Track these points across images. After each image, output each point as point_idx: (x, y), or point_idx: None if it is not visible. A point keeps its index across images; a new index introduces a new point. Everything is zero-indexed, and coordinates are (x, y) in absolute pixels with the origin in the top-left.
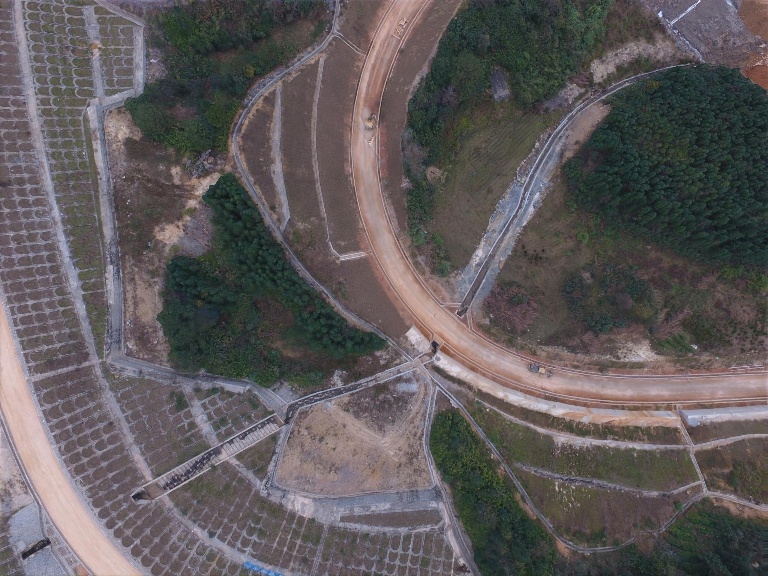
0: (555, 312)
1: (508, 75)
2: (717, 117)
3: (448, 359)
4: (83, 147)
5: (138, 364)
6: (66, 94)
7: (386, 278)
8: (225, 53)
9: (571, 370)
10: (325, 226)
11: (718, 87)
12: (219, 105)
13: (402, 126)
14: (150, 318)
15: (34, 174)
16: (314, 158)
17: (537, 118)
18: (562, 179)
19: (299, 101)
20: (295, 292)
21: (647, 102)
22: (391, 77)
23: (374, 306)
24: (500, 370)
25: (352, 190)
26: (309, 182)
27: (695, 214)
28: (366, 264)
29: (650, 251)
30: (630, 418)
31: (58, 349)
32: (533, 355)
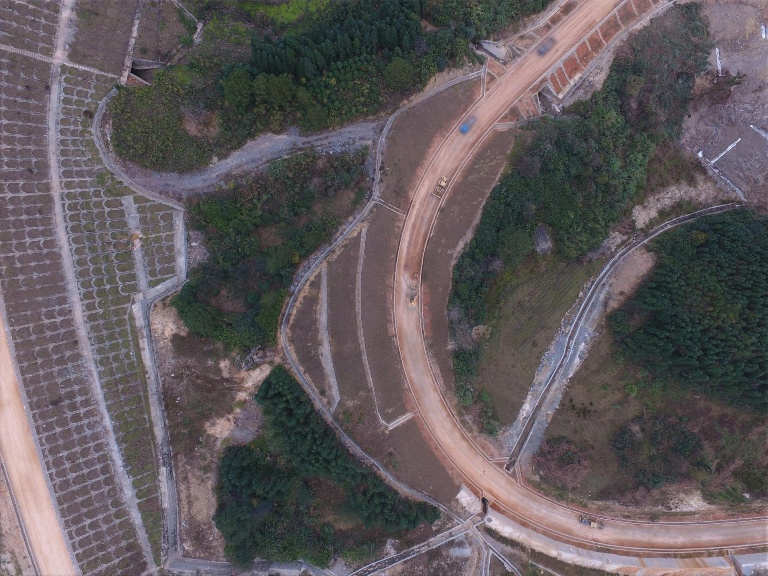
0: (605, 467)
1: (551, 229)
2: (767, 278)
3: (499, 519)
4: (130, 347)
5: (195, 563)
6: (110, 294)
7: (433, 437)
8: (265, 228)
9: (622, 520)
10: (373, 397)
11: (766, 241)
12: (267, 300)
13: (447, 291)
14: (204, 515)
15: (83, 384)
16: (359, 329)
17: (580, 268)
18: (608, 330)
19: (343, 276)
20: (347, 473)
21: (694, 257)
22: (432, 236)
23: (424, 471)
24: (551, 523)
25: (396, 351)
26: (356, 355)
27: (747, 374)
28: (413, 426)
29: (699, 401)
30: (684, 570)
31: (117, 565)
32: (583, 507)
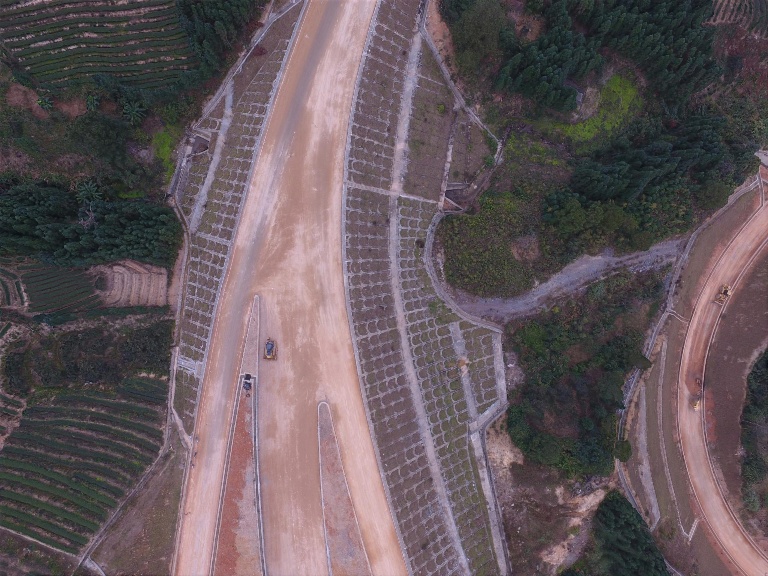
0: None
1: None
2: None
3: None
4: (472, 478)
5: None
6: (452, 425)
7: (718, 542)
8: None
9: None
10: (676, 509)
11: None
12: None
13: (740, 400)
14: None
15: (440, 522)
16: (661, 442)
17: None
18: None
19: (652, 392)
20: None
21: None
22: (714, 342)
23: None
24: None
25: (681, 457)
26: (661, 469)
27: None
28: (701, 532)
29: None
30: None
31: None
32: None
